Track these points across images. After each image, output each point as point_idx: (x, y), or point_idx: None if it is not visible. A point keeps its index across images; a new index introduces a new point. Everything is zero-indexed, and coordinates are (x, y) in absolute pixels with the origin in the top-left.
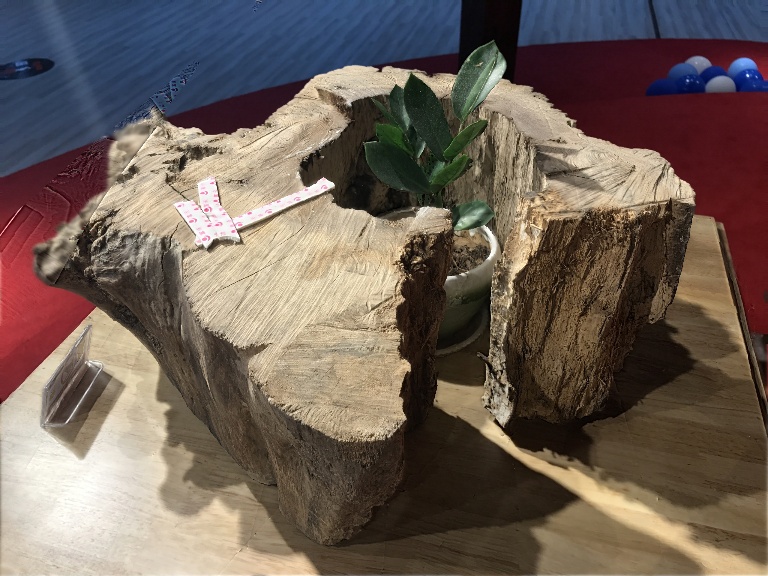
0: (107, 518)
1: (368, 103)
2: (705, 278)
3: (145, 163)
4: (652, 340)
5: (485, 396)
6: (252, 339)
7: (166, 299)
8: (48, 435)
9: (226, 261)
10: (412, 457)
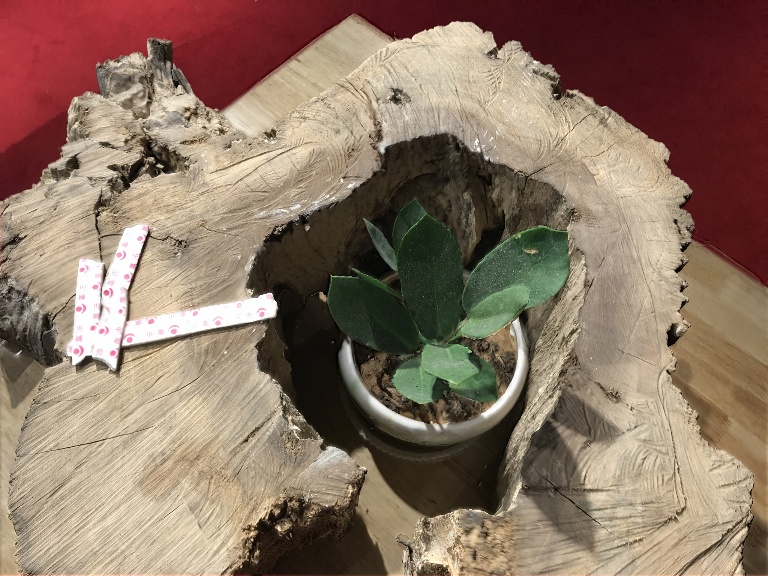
0: (6, 491)
1: (419, 143)
2: None
3: (89, 157)
4: None
5: (405, 554)
6: (35, 565)
7: None
8: None
9: (85, 398)
10: (301, 572)
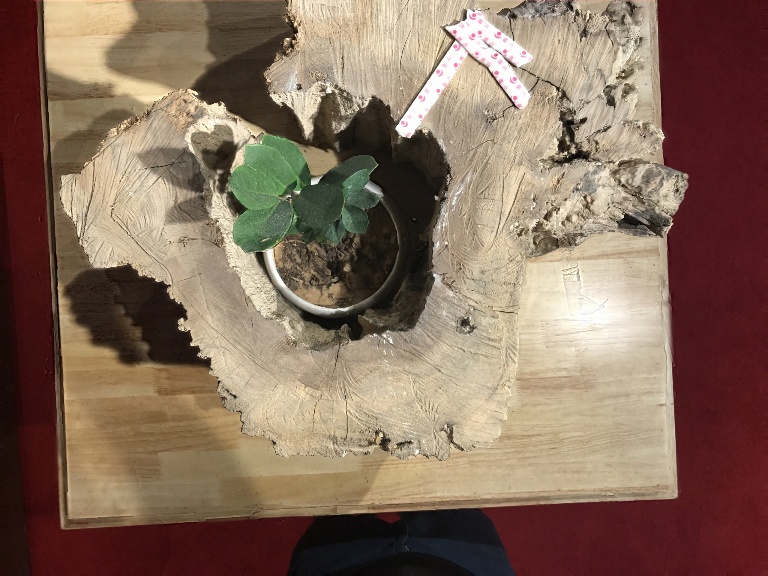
0: None
1: None
2: (86, 395)
3: (605, 113)
4: (137, 280)
5: None
6: None
7: None
8: None
9: (445, 3)
10: None
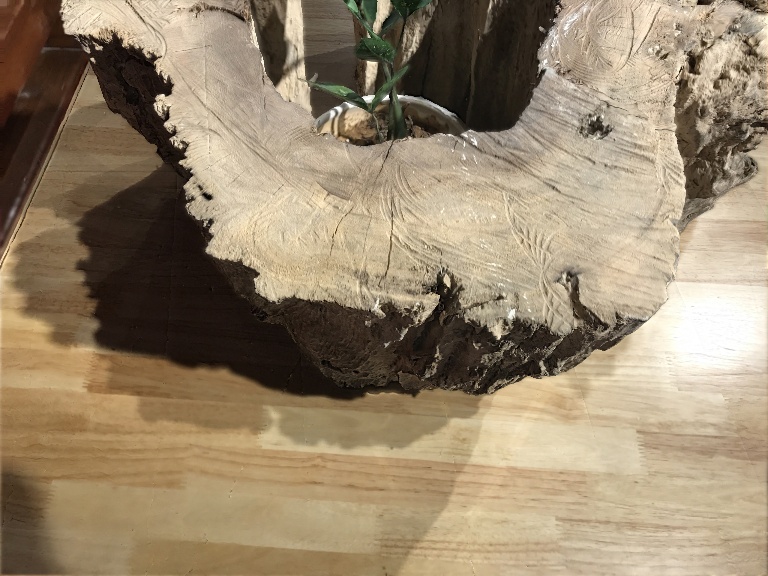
0: None
1: None
2: None
3: None
4: (115, 246)
5: None
6: None
7: None
8: None
9: None
10: None
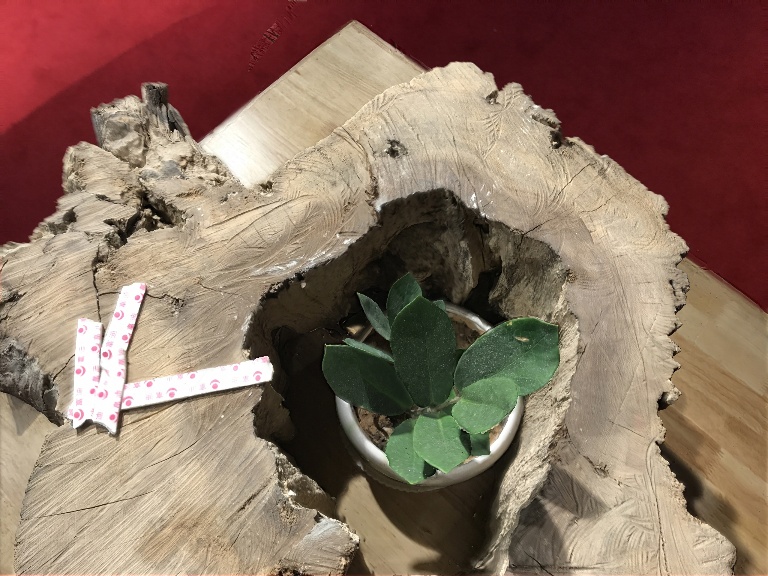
0: (15, 518)
1: (416, 198)
2: None
3: (86, 211)
4: None
5: None
6: None
7: (53, 420)
8: None
9: (86, 462)
10: None
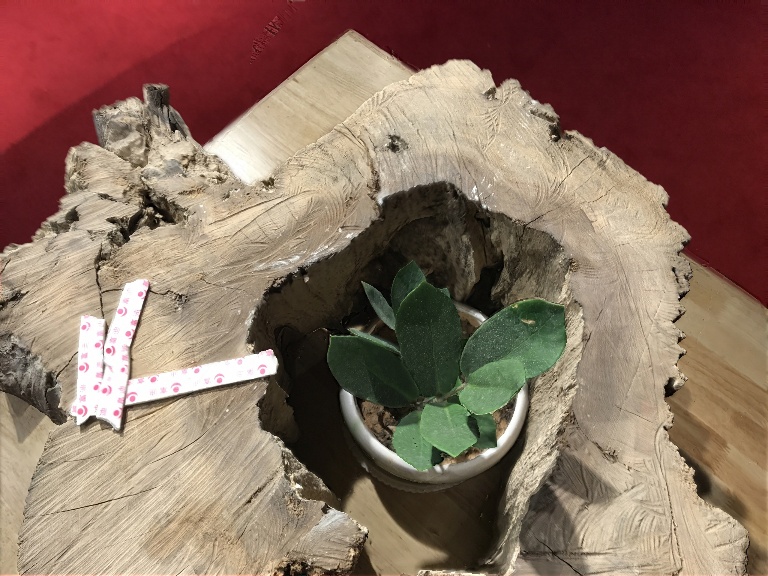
0: (15, 527)
1: (417, 192)
2: None
3: (88, 210)
4: None
5: None
6: None
7: (55, 420)
8: (4, 396)
9: (90, 458)
10: None
